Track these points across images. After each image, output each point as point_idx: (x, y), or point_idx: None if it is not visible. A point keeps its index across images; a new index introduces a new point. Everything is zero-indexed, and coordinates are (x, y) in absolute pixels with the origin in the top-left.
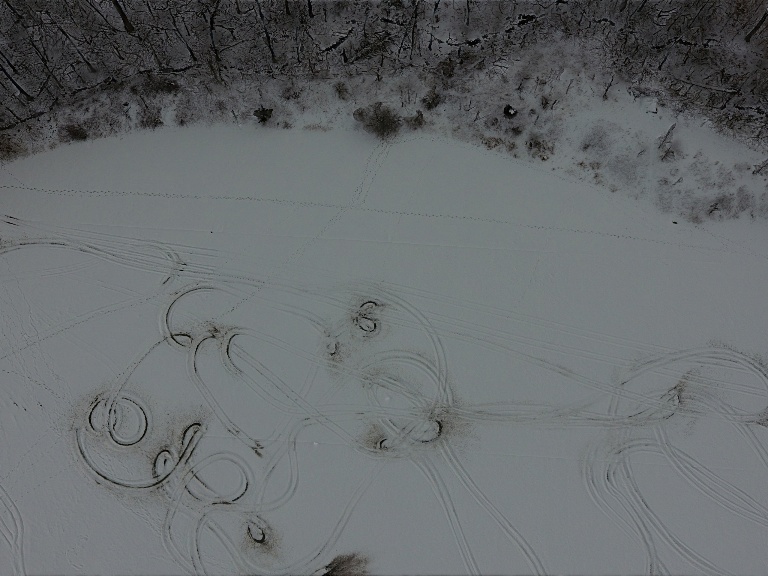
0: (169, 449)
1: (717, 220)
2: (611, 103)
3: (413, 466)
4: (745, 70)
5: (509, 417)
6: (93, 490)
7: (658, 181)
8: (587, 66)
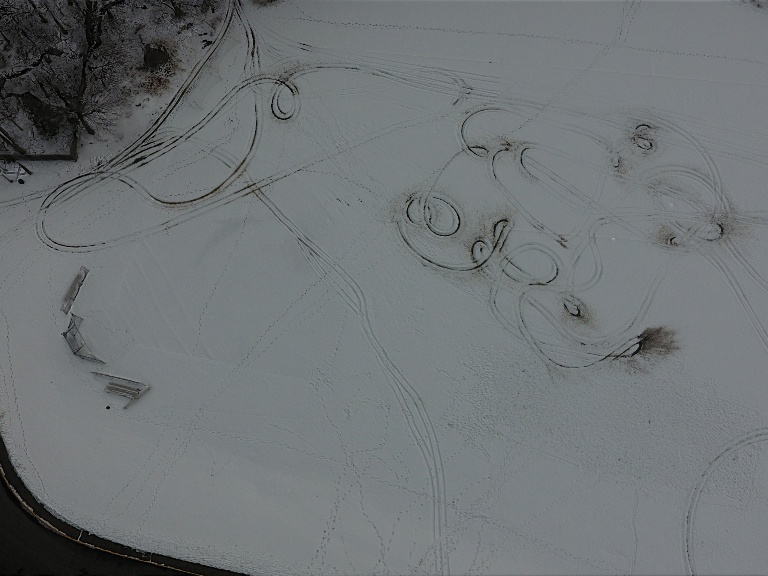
0: (483, 240)
1: None
2: None
3: (703, 259)
4: None
5: None
6: (421, 271)
7: None
8: None
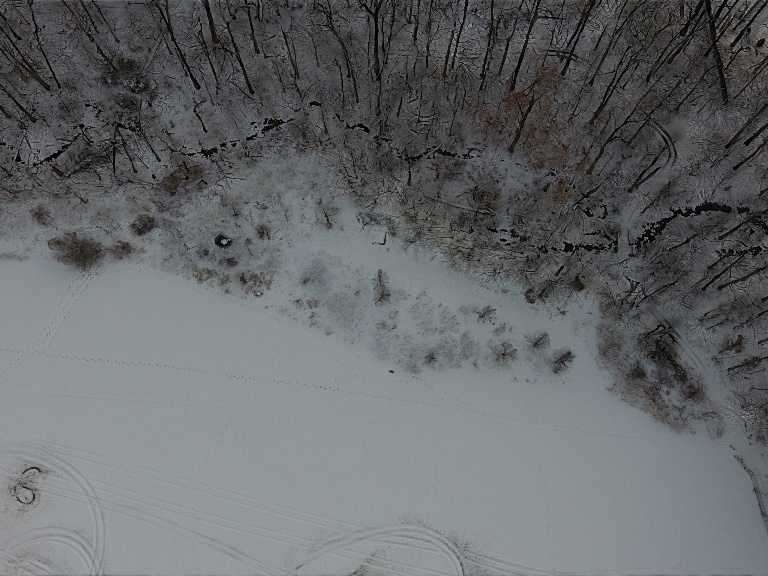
0: None
1: (437, 369)
2: (336, 232)
3: None
4: (504, 186)
5: None
6: None
7: (376, 324)
8: (317, 187)
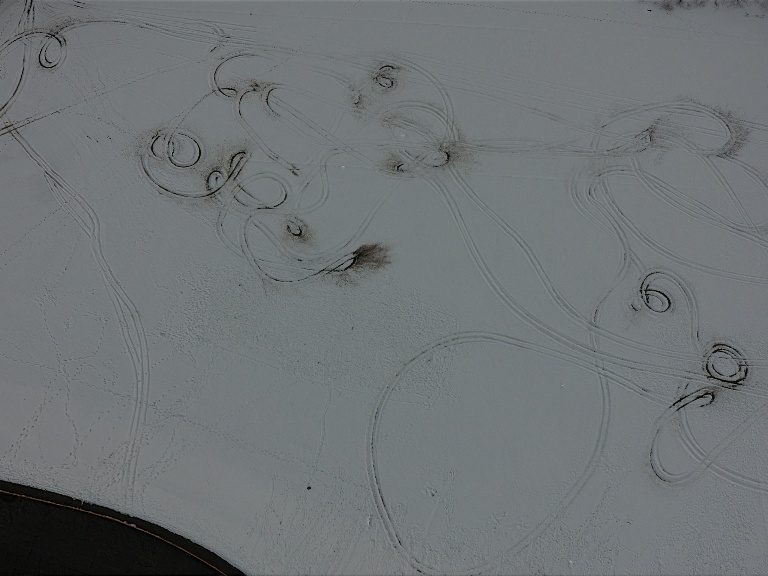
0: (220, 170)
1: (686, 8)
2: None
3: (425, 183)
4: None
5: (506, 149)
6: (157, 198)
7: None
8: None
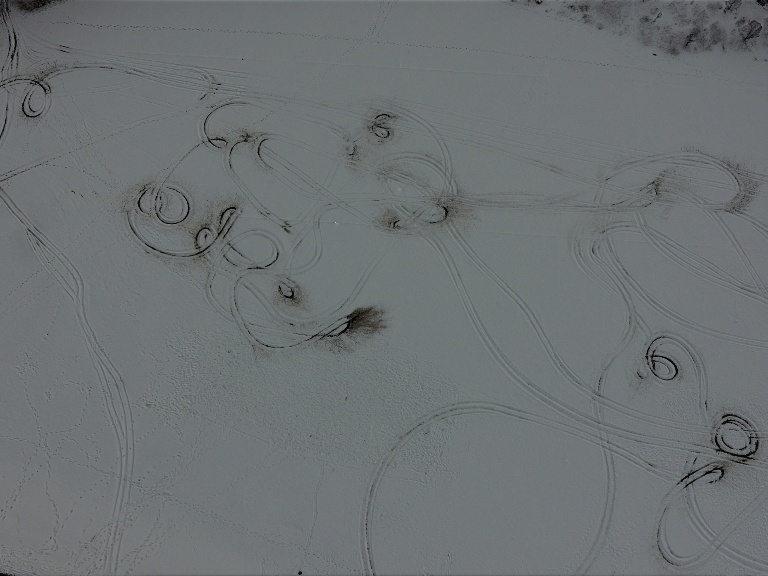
0: (209, 227)
1: (692, 52)
2: None
3: (423, 241)
4: None
5: (507, 204)
6: (143, 257)
7: (640, 19)
8: None
